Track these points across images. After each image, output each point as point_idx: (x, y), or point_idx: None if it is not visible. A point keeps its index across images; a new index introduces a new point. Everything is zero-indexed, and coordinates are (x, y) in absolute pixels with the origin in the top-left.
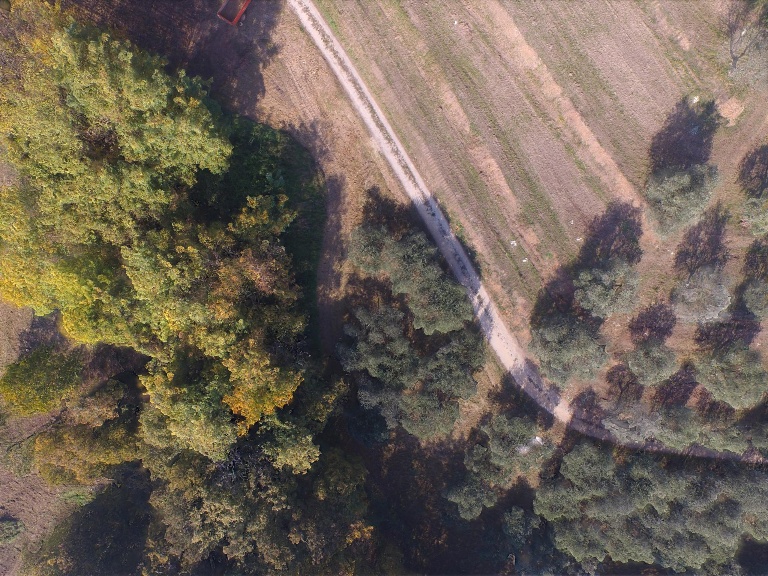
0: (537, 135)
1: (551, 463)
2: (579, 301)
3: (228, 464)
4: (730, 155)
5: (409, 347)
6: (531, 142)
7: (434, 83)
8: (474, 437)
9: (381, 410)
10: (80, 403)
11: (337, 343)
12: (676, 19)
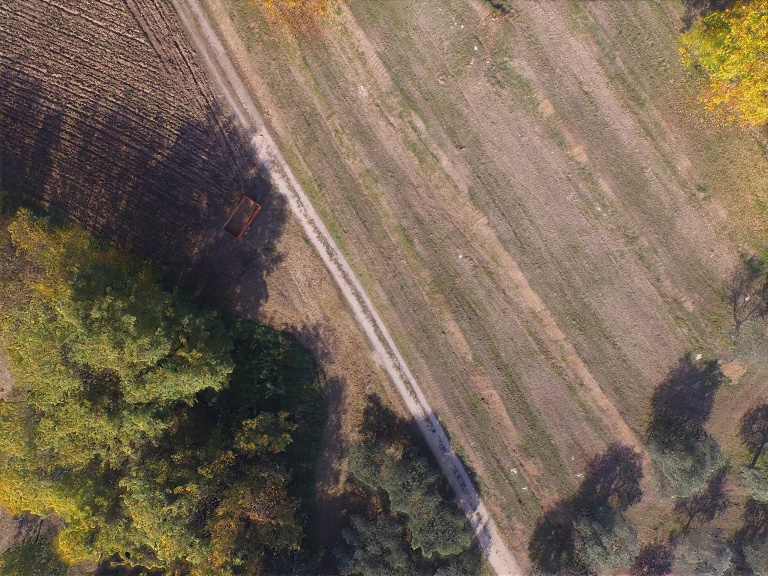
0: (539, 371)
1: None
2: (578, 552)
3: None
4: (732, 410)
5: (407, 559)
6: (533, 377)
7: (437, 309)
8: None
9: None
10: None
11: (334, 548)
12: (680, 282)
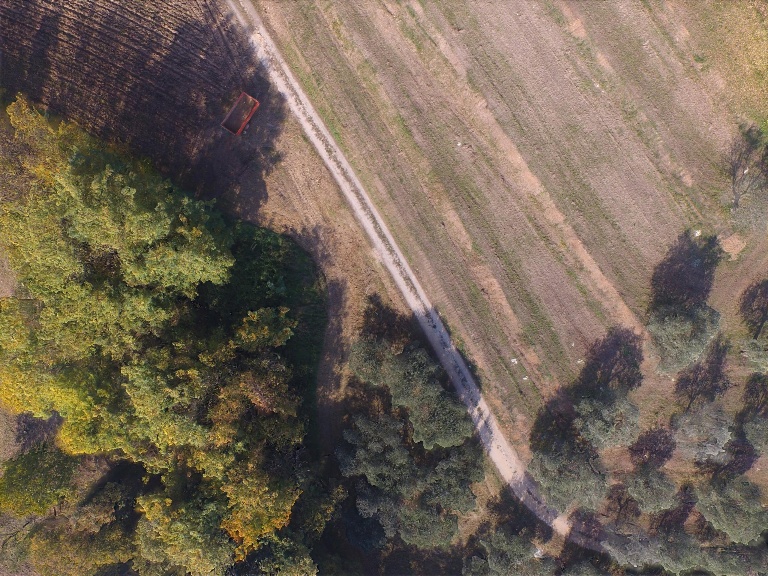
0: (539, 258)
1: (549, 574)
2: (579, 431)
3: None
4: (731, 288)
5: (408, 457)
6: (533, 264)
7: (437, 200)
8: (472, 544)
9: (379, 518)
10: (77, 511)
11: (336, 449)
12: (679, 156)
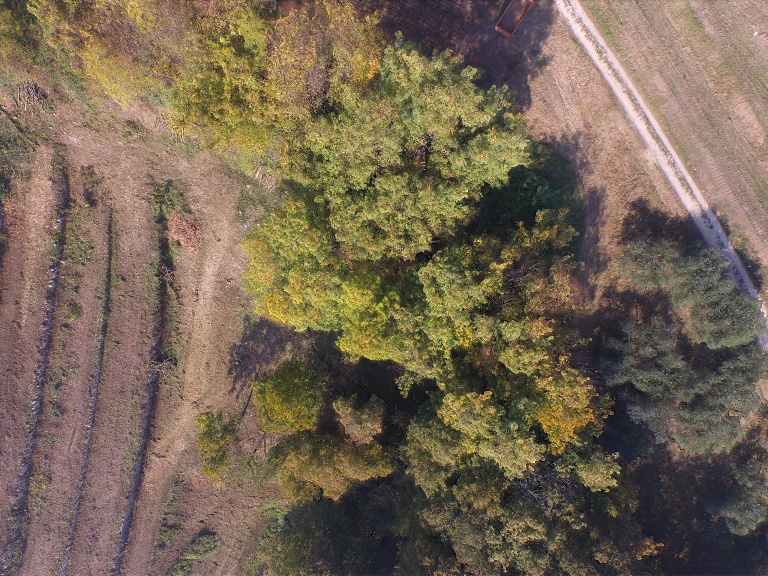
0: None
1: None
2: None
3: (526, 482)
4: None
5: None
6: None
7: (724, 94)
8: (738, 451)
9: (648, 425)
10: (355, 420)
11: (601, 357)
12: None
